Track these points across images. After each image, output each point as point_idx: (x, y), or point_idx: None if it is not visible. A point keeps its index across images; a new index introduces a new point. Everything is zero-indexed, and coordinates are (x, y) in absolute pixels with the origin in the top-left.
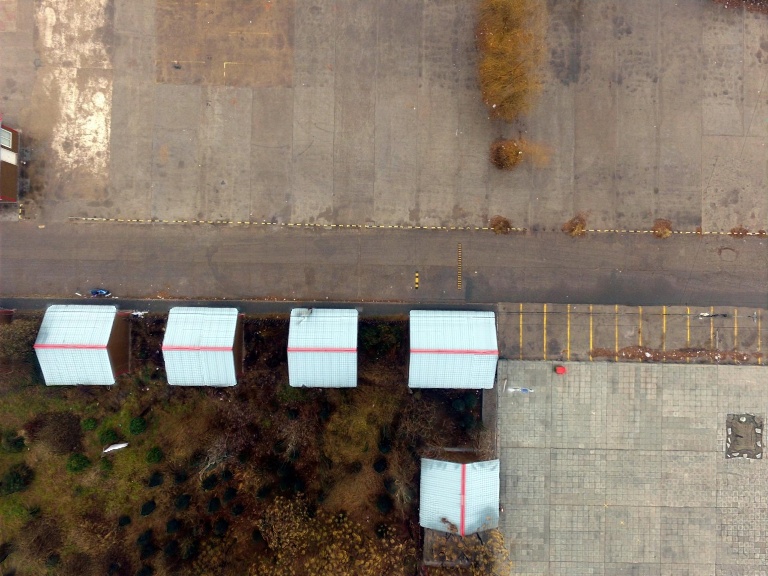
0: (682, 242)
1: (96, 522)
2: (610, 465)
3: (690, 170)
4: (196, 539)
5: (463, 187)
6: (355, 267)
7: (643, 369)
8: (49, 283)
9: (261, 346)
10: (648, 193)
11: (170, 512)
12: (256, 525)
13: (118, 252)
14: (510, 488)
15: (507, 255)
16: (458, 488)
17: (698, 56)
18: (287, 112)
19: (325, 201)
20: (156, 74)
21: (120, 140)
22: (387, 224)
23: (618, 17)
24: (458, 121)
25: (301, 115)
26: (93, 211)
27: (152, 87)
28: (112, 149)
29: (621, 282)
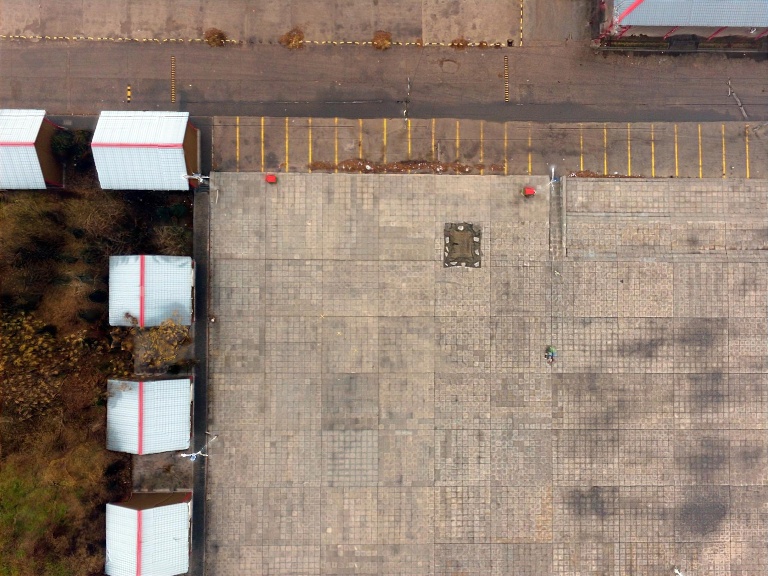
0: (403, 54)
1: None
2: (326, 276)
3: None
4: None
5: None
6: (64, 80)
7: (359, 179)
8: None
9: None
10: (367, 5)
11: None
12: None
13: None
14: (224, 300)
15: (223, 68)
16: (137, 280)
17: None
18: None
19: (31, 13)
20: None
21: None
22: (96, 36)
23: None
24: None
25: None
26: None
27: None
28: None
29: (341, 95)
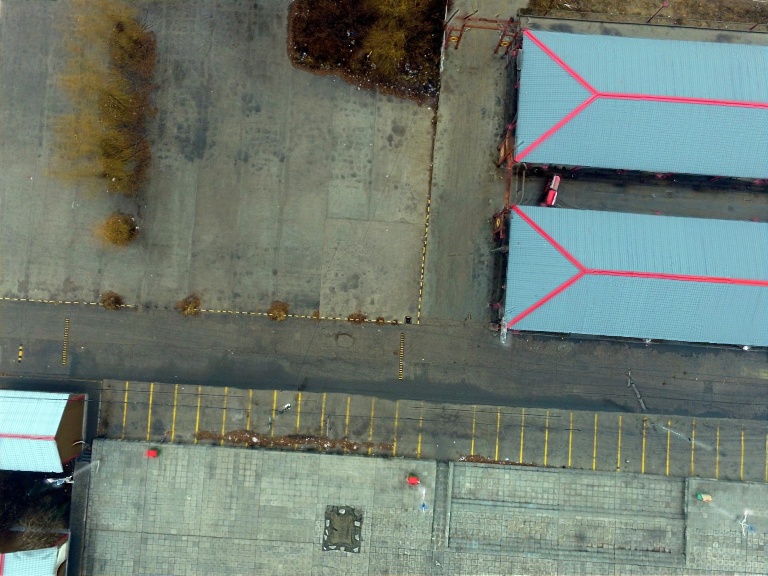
0: (298, 326)
1: None
2: (202, 552)
3: (311, 253)
4: None
5: (75, 260)
6: None
7: (243, 455)
8: None
9: None
10: (266, 274)
11: None
12: None
13: None
14: (97, 572)
15: (116, 331)
16: None
17: (327, 137)
18: None
19: None
20: None
21: None
22: None
23: (247, 94)
24: (75, 193)
25: None
26: None
27: None
28: None
29: (233, 364)
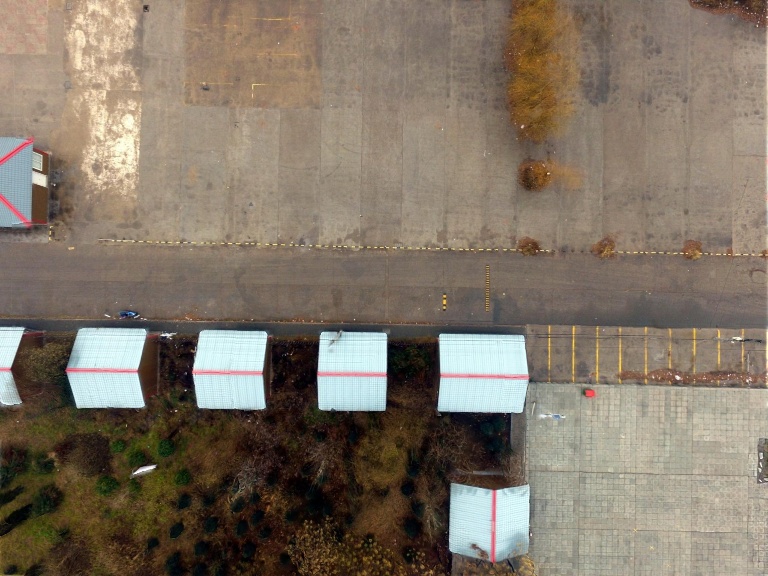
0: (712, 264)
1: (125, 543)
2: (640, 489)
3: (721, 191)
4: (225, 562)
5: (491, 208)
6: (383, 289)
7: (673, 392)
8: (78, 304)
9: (289, 368)
10: (678, 214)
11: (198, 534)
12: (286, 550)
13: (147, 274)
14: (538, 512)
15: (535, 277)
16: (489, 514)
17: (729, 76)
18: (315, 133)
19: (353, 222)
20: (185, 96)
21: (149, 162)
22: (415, 246)
23: (648, 37)
24: (486, 142)
25: (329, 136)
26: (122, 233)
27: (181, 109)
28: (141, 171)
29: (650, 304)
